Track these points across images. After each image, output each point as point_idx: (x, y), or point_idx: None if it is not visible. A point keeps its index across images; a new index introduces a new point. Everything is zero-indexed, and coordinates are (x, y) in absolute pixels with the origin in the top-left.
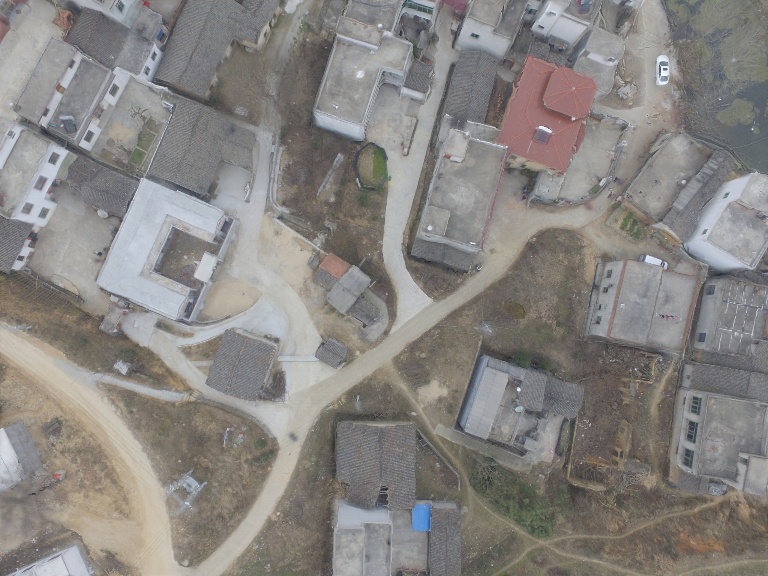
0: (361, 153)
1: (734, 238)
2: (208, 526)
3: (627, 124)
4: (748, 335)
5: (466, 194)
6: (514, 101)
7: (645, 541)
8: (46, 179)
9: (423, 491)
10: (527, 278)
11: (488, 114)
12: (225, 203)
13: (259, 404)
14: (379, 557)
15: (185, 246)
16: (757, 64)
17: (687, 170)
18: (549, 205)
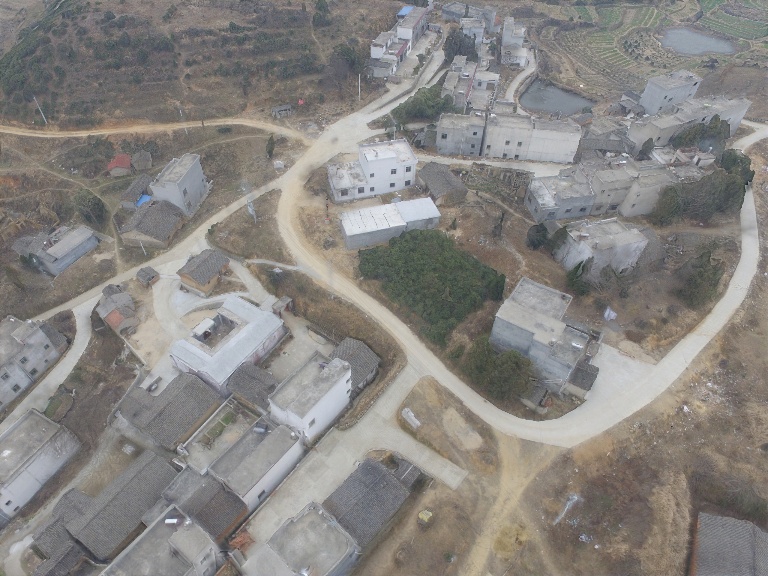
0: None
1: None
2: (258, 202)
3: None
4: None
5: None
6: None
7: (35, 185)
8: None
9: None
10: None
11: None
12: None
13: None
14: None
15: None
16: None
17: None
18: None
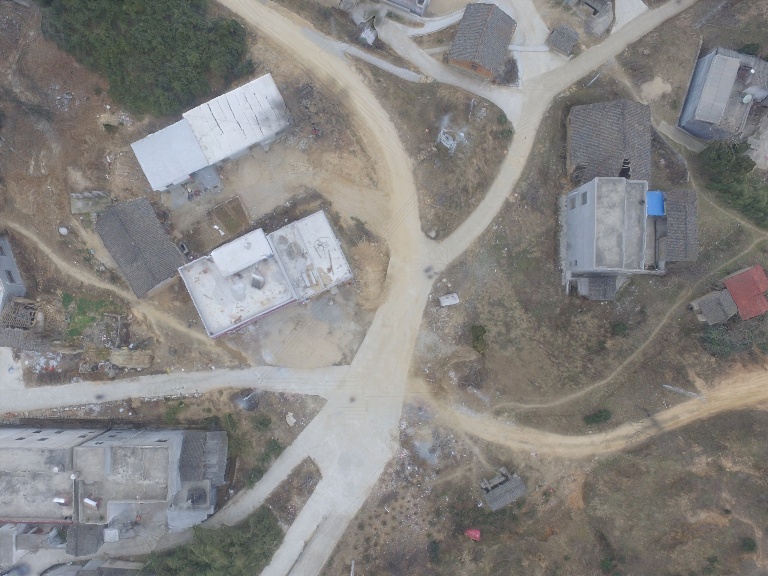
0: None
1: None
2: (453, 199)
3: None
4: None
5: None
6: None
7: None
8: None
9: None
10: None
11: None
12: None
13: (493, 89)
14: (631, 218)
15: None
16: None
17: None
18: None
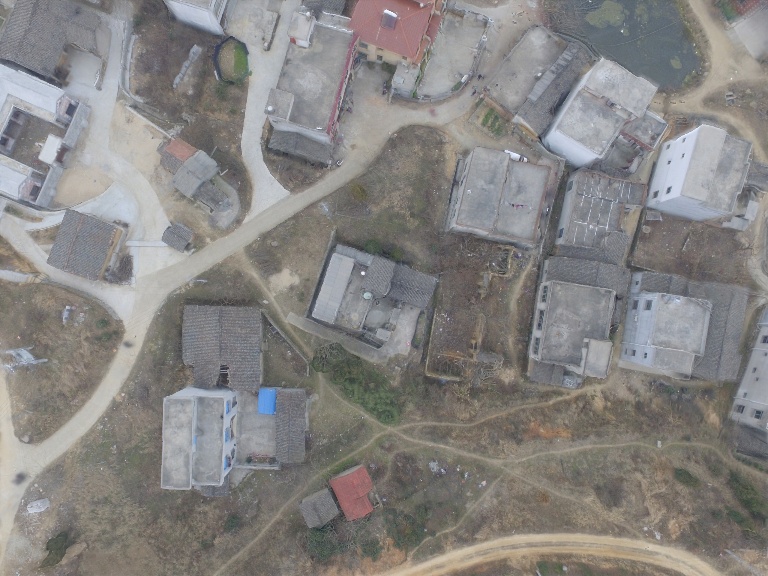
0: (222, 48)
1: (585, 127)
2: (49, 403)
3: (487, 19)
4: (603, 228)
5: (314, 80)
6: None
7: (493, 428)
8: None
9: (275, 379)
10: (384, 171)
11: (347, 8)
12: (77, 90)
13: (105, 287)
14: (214, 431)
15: (36, 133)
16: None
17: (545, 64)
18: (411, 102)
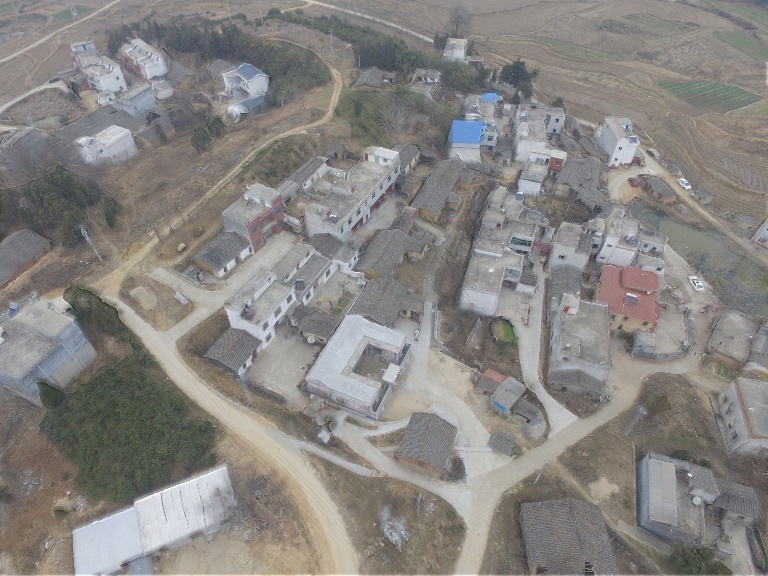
0: (492, 323)
1: None
2: None
3: (687, 308)
4: None
5: (586, 333)
6: (602, 284)
7: None
8: (280, 311)
9: None
10: None
11: None
12: None
13: (442, 484)
14: None
15: (369, 367)
16: (761, 285)
17: (749, 332)
18: (649, 357)
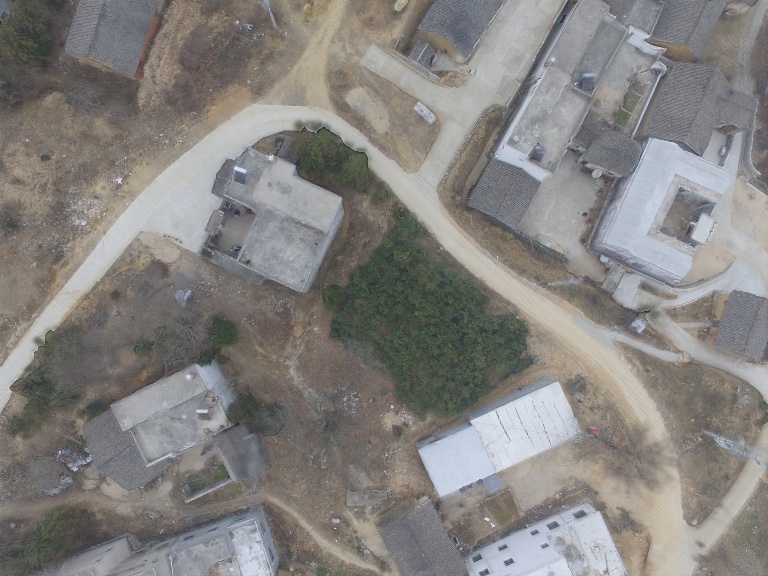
0: None
1: None
2: (714, 486)
3: None
4: None
5: None
6: None
7: None
8: None
9: None
10: None
11: None
12: None
13: (747, 366)
14: None
15: None
16: None
17: None
18: None
